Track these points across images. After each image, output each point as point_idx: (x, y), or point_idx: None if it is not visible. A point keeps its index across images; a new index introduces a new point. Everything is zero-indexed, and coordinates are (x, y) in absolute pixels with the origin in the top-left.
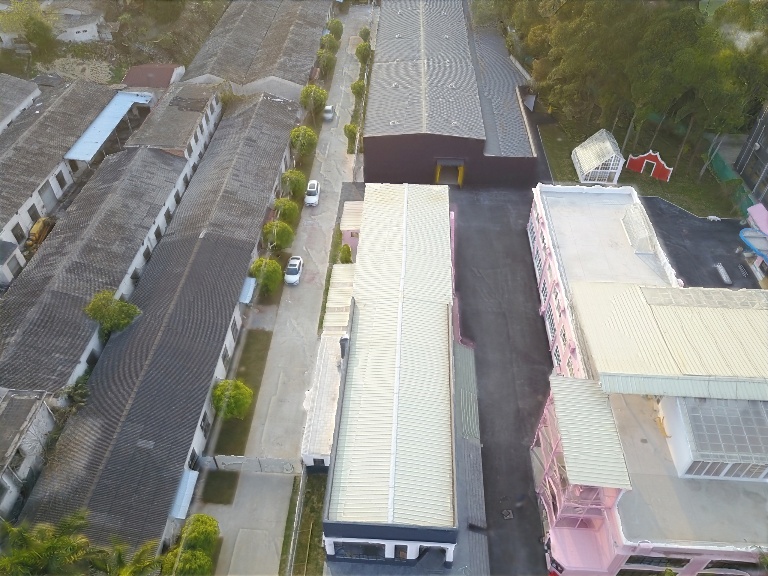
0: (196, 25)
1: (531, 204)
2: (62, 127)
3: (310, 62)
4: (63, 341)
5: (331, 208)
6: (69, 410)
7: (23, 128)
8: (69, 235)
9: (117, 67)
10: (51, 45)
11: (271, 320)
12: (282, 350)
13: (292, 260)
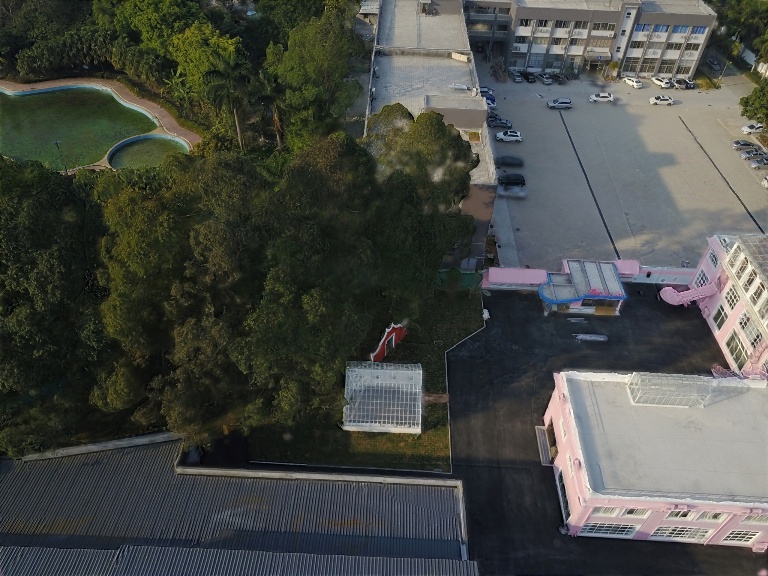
0: None
1: (502, 517)
2: None
3: None
4: None
5: None
6: None
7: None
8: None
9: None
10: None
11: None
12: None
13: None
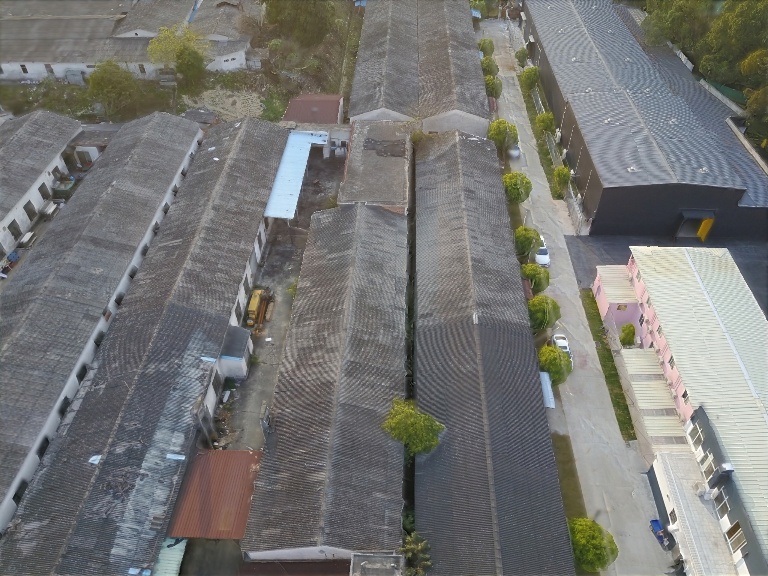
0: (330, 46)
1: None
2: (251, 177)
3: (483, 91)
4: (377, 474)
5: (565, 269)
6: (415, 572)
7: (209, 180)
8: (322, 322)
9: (268, 98)
10: (198, 75)
11: (560, 420)
12: (591, 462)
13: (559, 341)
